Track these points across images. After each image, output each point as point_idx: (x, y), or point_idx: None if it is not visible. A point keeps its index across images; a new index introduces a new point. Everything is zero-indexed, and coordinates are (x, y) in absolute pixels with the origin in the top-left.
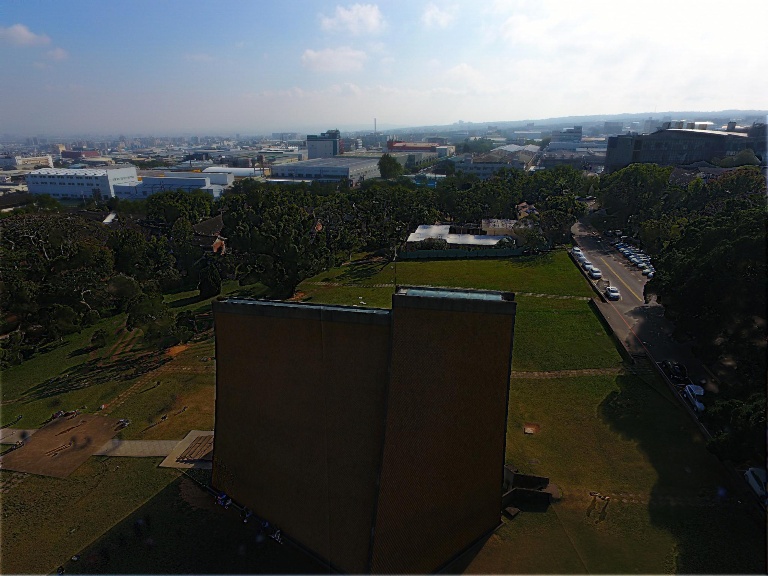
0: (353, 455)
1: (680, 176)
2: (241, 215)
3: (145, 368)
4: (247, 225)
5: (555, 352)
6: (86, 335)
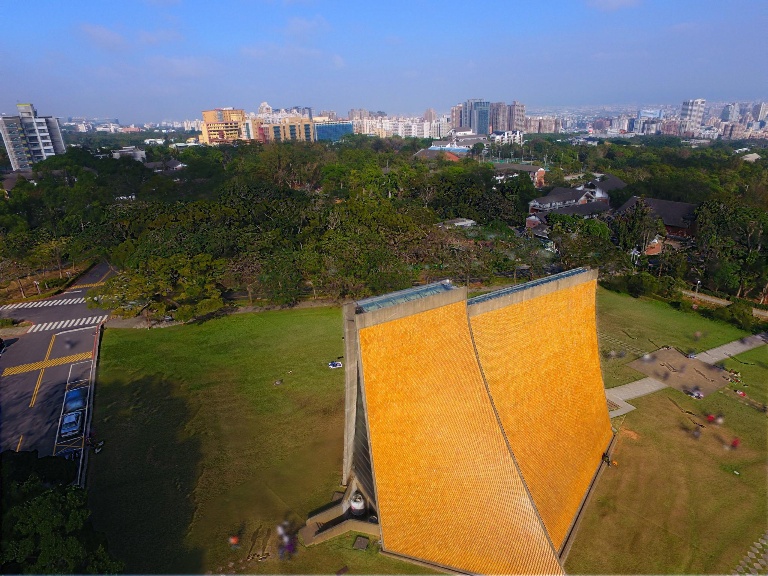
0: None
1: None
2: None
3: None
4: None
5: None
6: None
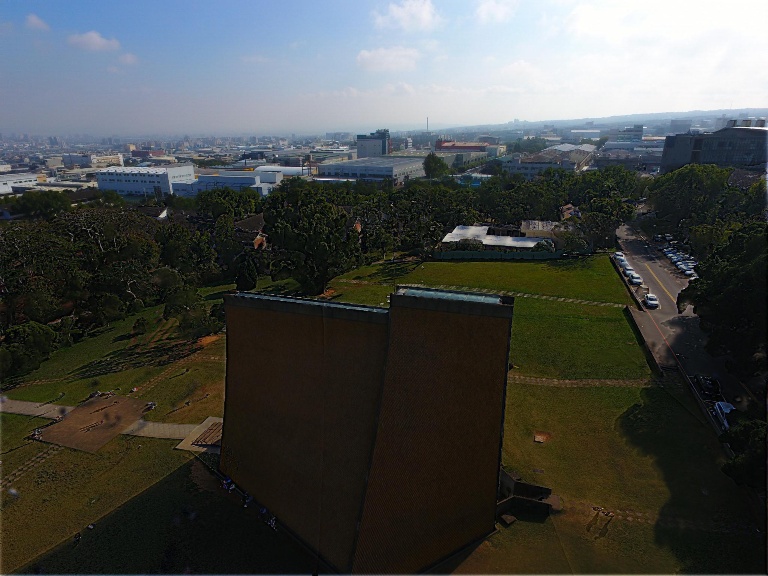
0: (347, 450)
1: (742, 178)
2: (280, 213)
3: (177, 356)
4: (285, 222)
5: (579, 360)
6: (130, 322)
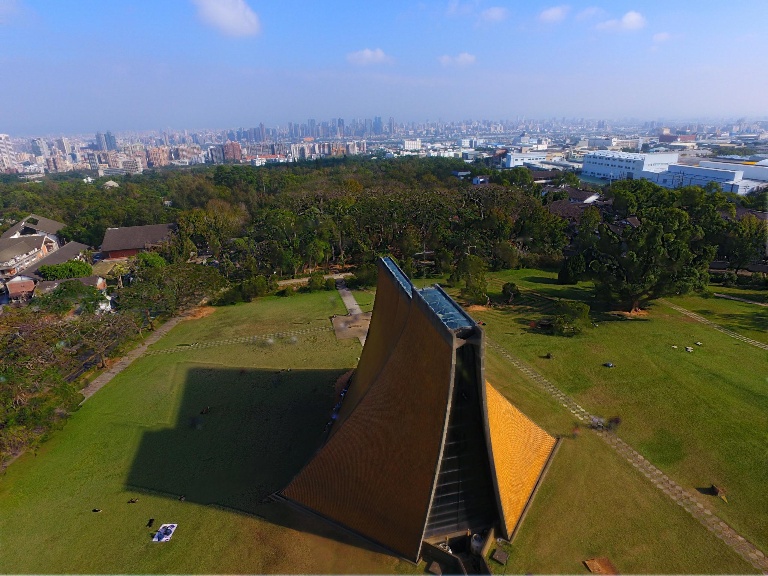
0: None
1: None
2: None
3: None
4: None
5: None
6: None
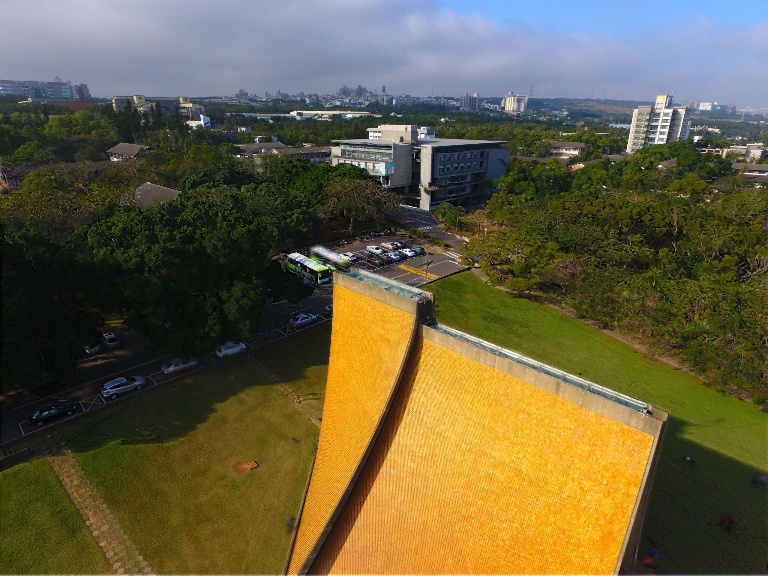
0: None
1: None
2: None
3: None
4: None
5: (4, 544)
6: None
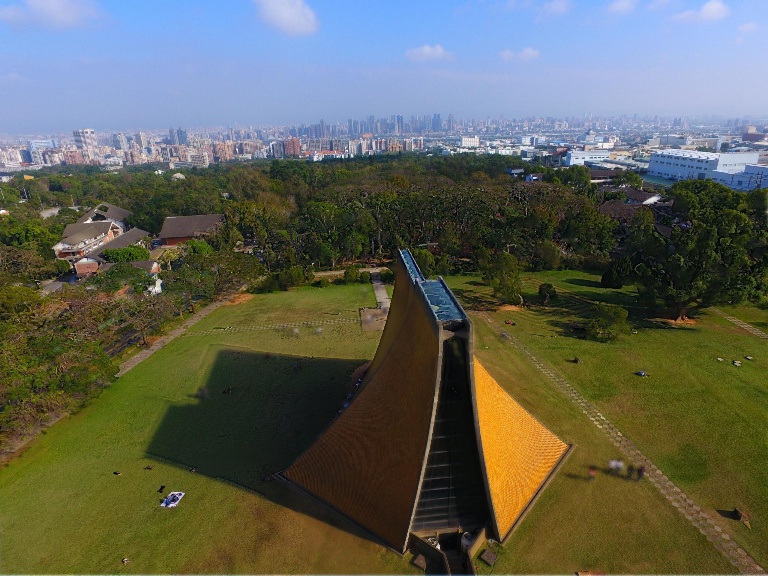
0: None
1: None
2: None
3: (475, 307)
4: None
5: None
6: None
